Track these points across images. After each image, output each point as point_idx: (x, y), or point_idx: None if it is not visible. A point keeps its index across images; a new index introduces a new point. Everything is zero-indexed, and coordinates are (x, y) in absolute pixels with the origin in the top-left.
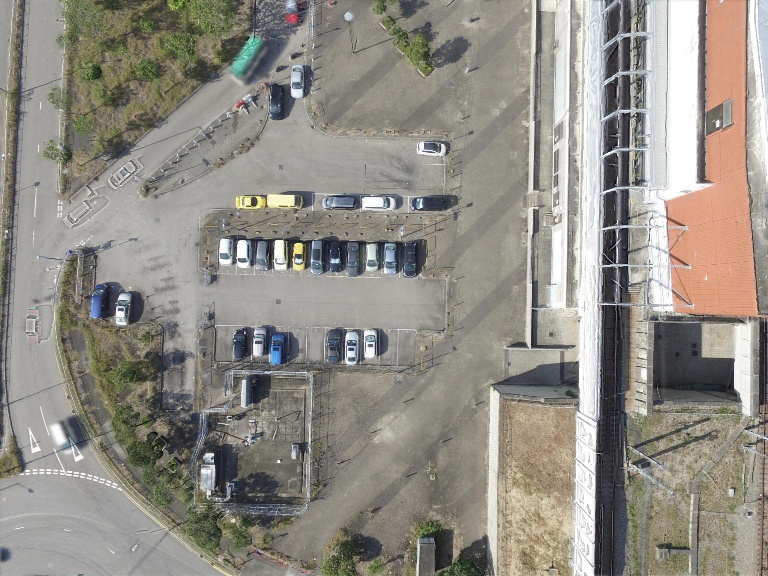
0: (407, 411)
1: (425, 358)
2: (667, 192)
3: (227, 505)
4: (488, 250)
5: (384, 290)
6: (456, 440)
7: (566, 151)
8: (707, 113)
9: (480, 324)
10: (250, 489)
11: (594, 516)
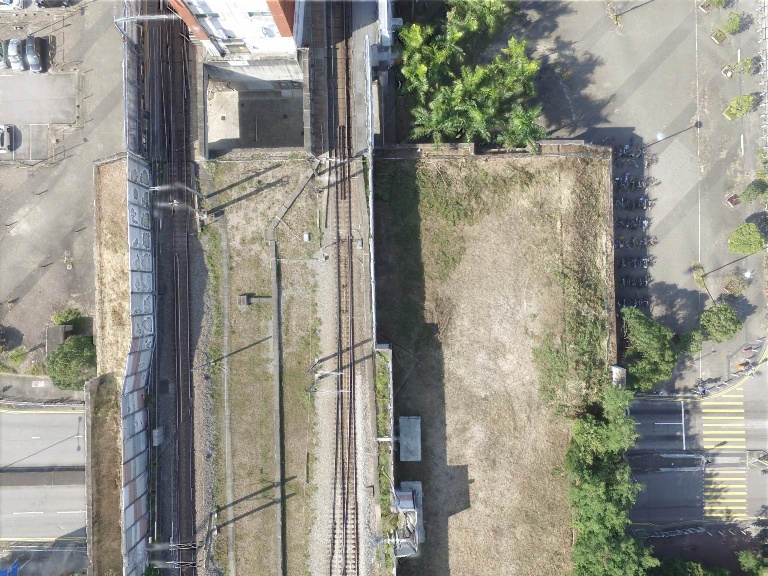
0: (41, 203)
1: (57, 151)
2: None
3: None
4: (115, 42)
5: (16, 87)
6: (90, 229)
7: None
8: None
9: (109, 115)
10: None
11: (129, 244)
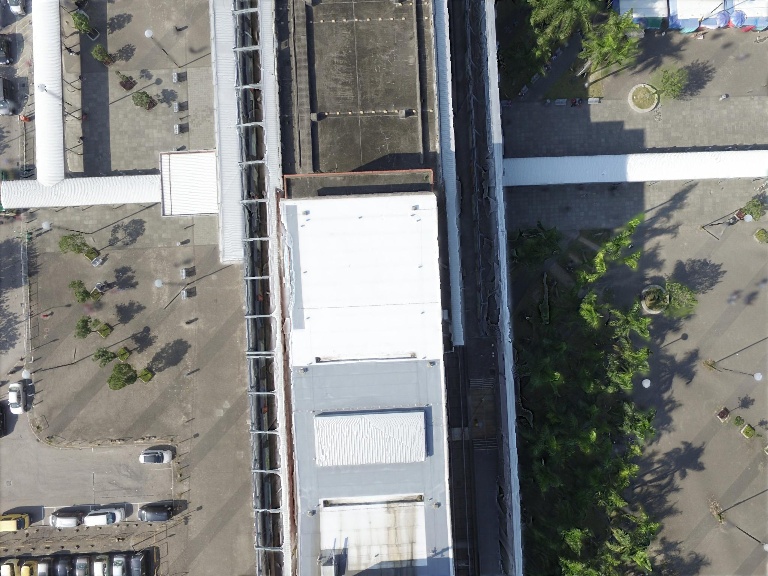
0: None
1: None
2: None
3: None
4: (220, 552)
5: None
6: None
7: None
8: None
9: None
10: None
11: None
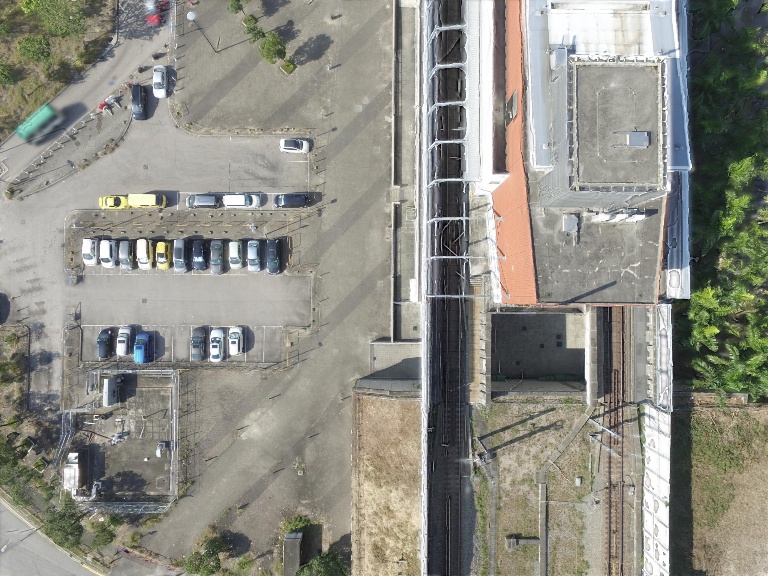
0: (274, 407)
1: (291, 354)
2: (482, 184)
3: (95, 504)
4: (352, 245)
5: (250, 287)
6: (323, 435)
7: (417, 145)
8: (507, 104)
9: (345, 319)
10: (118, 488)
11: (426, 507)
